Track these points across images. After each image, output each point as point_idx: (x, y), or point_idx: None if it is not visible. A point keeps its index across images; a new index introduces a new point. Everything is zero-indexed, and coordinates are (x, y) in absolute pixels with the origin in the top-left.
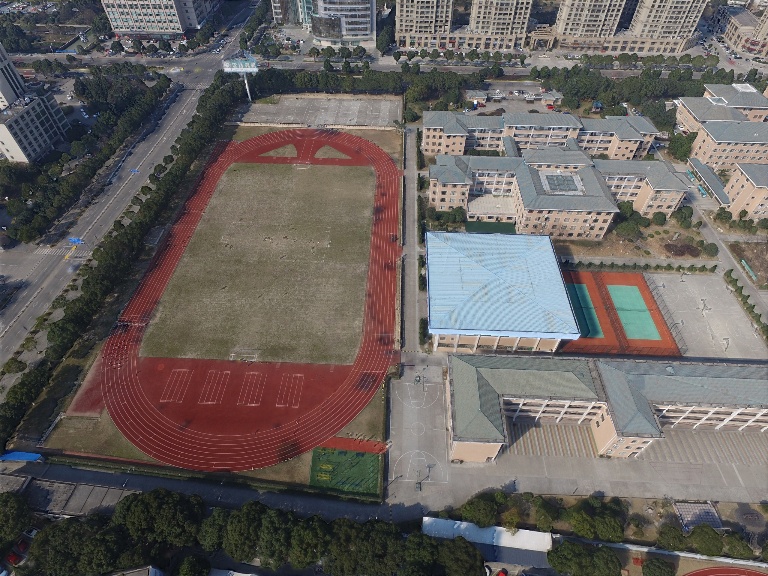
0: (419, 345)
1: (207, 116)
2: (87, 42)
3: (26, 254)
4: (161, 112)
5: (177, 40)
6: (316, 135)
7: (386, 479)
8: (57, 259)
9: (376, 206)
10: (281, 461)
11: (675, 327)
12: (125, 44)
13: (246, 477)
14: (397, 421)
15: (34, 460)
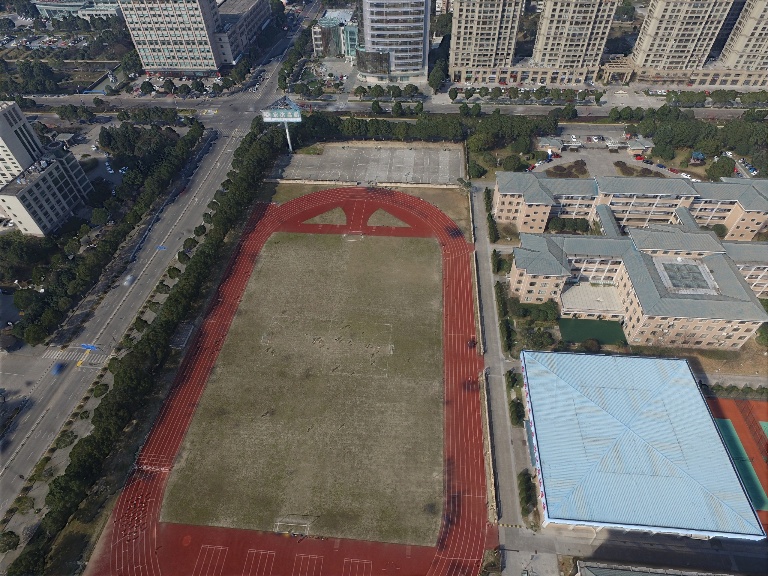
0: (521, 515)
1: (244, 176)
2: (116, 82)
3: (33, 358)
4: (193, 166)
5: (211, 77)
6: (367, 195)
7: None
8: (68, 366)
9: (445, 294)
10: None
11: None
12: (156, 82)
13: None
14: None
15: None
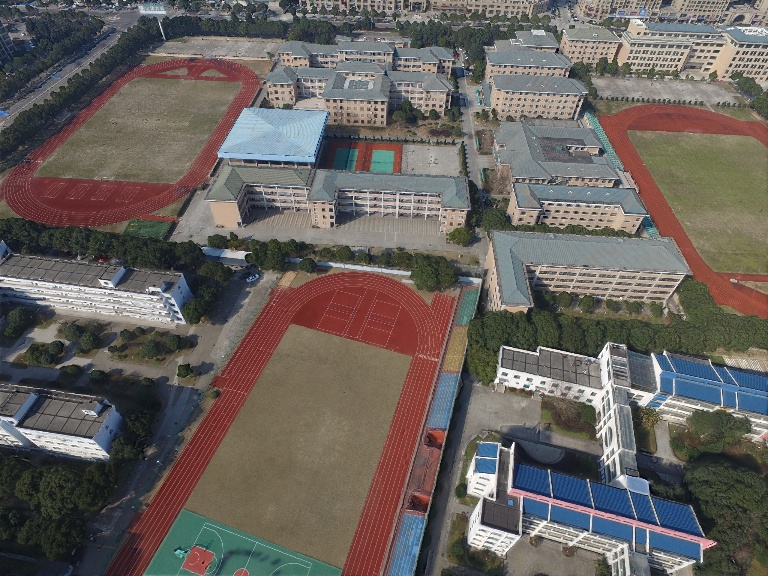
0: None
1: (121, 44)
2: None
3: None
4: (92, 45)
5: None
6: (207, 62)
7: (171, 233)
8: None
9: (232, 104)
10: (109, 224)
11: (406, 172)
12: (78, 0)
13: None
14: (191, 209)
15: None
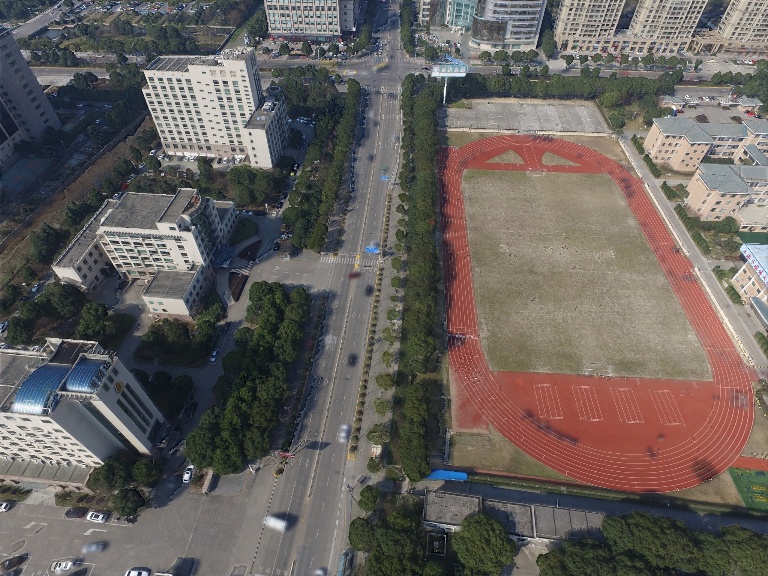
0: None
1: (429, 121)
2: None
3: (313, 263)
4: (360, 116)
5: (332, 42)
6: (531, 141)
7: None
8: (348, 268)
9: (636, 215)
10: (702, 481)
11: None
12: None
13: (677, 498)
14: None
15: (466, 479)
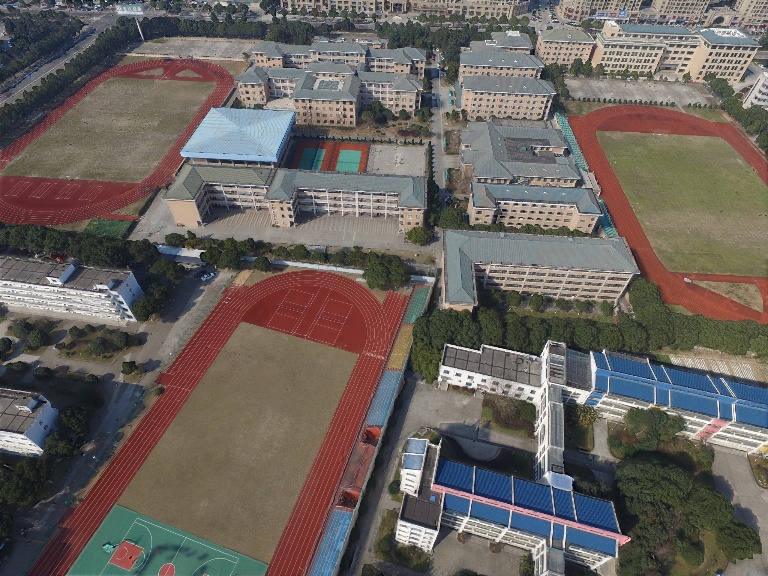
0: None
1: (97, 44)
2: None
3: None
4: (71, 46)
5: None
6: (183, 63)
7: (131, 231)
8: None
9: (204, 104)
10: (70, 222)
11: (371, 171)
12: (61, 1)
13: None
14: (153, 208)
15: None
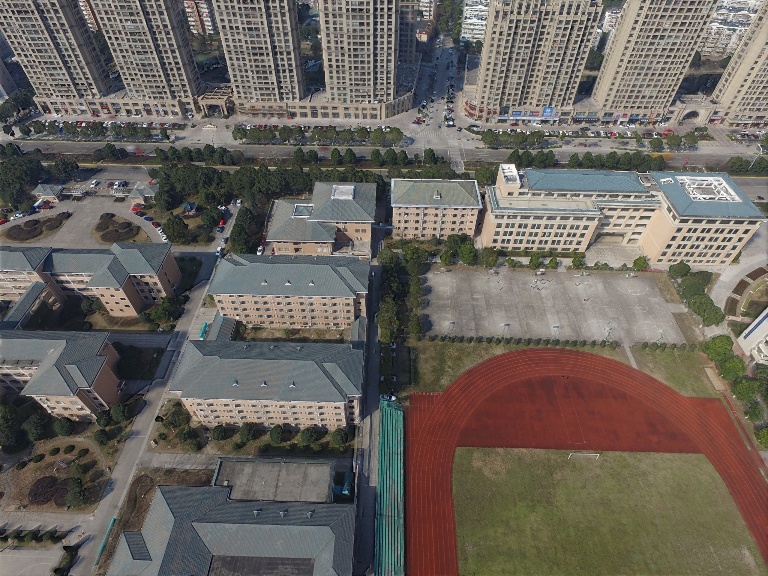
0: None
1: None
2: None
3: None
4: None
5: None
6: None
7: None
8: None
9: None
10: None
11: None
12: None
13: None
14: None
15: None
